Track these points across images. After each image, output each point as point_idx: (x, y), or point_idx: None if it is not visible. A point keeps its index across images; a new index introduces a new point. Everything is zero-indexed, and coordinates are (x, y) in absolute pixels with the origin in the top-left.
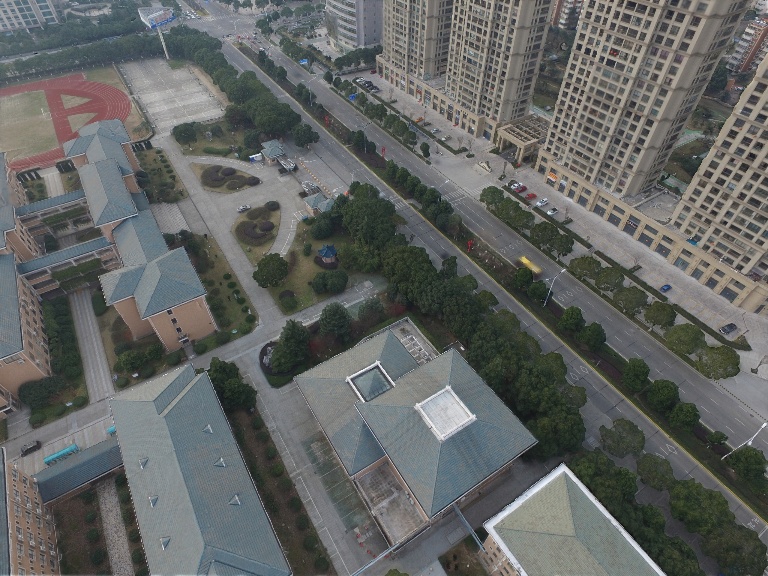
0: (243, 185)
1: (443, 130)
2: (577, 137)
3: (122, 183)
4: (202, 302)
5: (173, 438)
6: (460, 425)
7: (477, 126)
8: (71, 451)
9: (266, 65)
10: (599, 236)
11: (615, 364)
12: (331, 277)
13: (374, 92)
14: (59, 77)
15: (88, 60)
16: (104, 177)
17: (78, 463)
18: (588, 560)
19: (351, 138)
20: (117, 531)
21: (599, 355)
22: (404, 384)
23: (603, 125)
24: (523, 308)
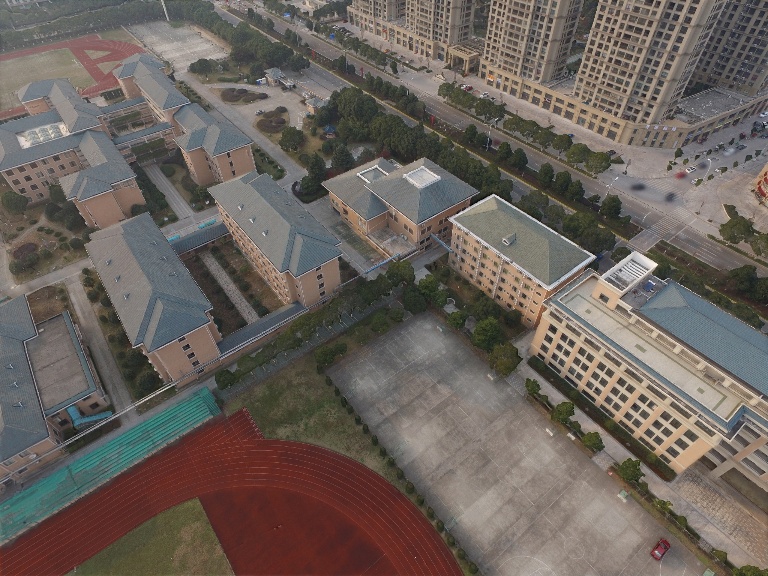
0: (255, 99)
1: (406, 57)
2: (505, 42)
3: (173, 86)
4: (249, 151)
5: (258, 191)
6: (431, 181)
7: (433, 50)
8: (177, 238)
9: (256, 19)
10: (525, 112)
11: (534, 175)
12: (335, 142)
13: (348, 35)
14: (78, 38)
15: (101, 23)
16: (159, 82)
17: (186, 238)
18: (505, 217)
19: (335, 64)
20: (219, 272)
21: (524, 172)
22: (395, 173)
23: (521, 28)
24: (472, 154)
